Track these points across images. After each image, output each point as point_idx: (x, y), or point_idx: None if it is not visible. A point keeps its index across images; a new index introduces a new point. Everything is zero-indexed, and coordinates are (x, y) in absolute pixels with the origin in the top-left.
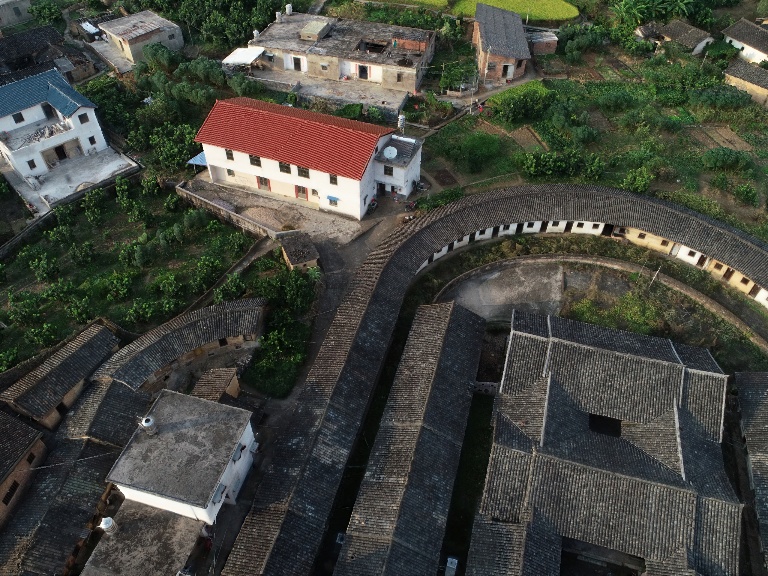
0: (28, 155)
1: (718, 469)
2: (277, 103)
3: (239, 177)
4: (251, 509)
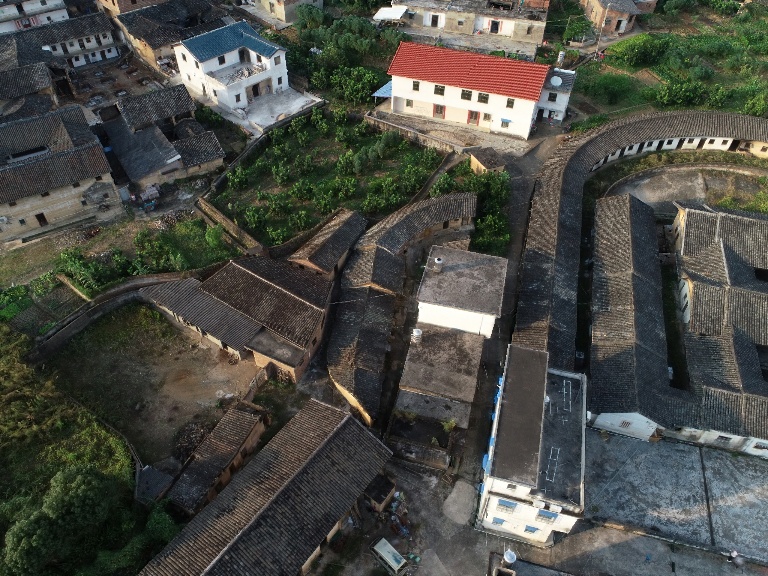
0: (237, 90)
1: None
2: None
3: (417, 107)
4: (515, 329)
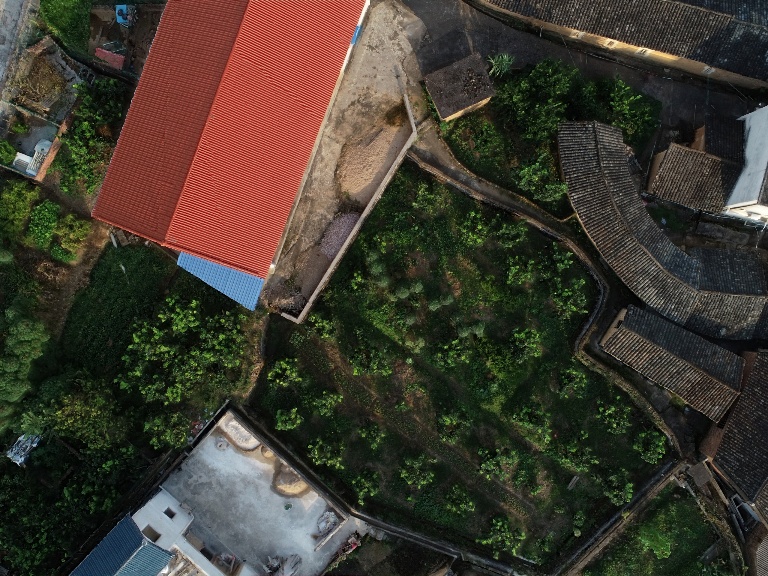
0: None
1: None
2: (16, 184)
3: None
4: None
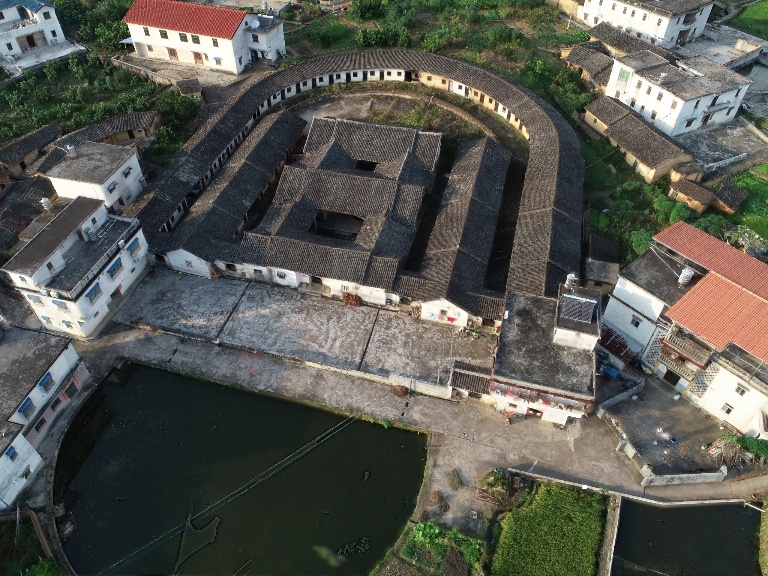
0: (7, 39)
1: (426, 182)
2: None
3: (156, 51)
4: None
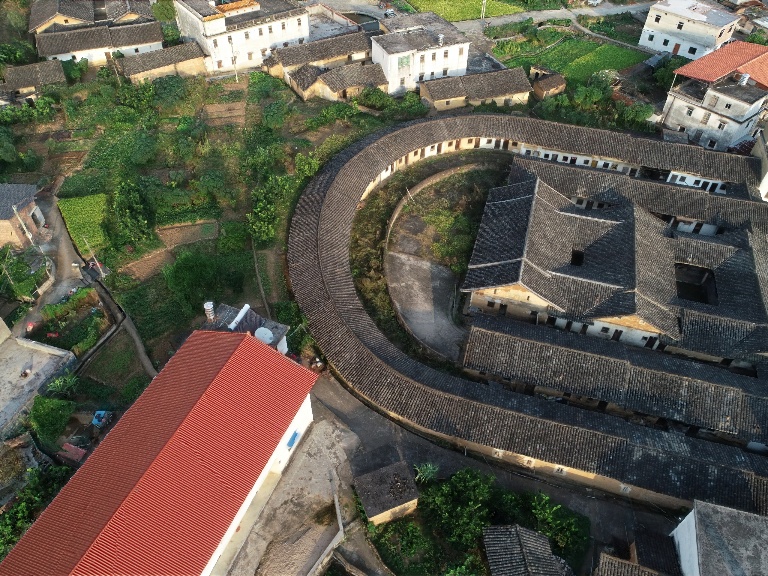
0: None
1: (596, 211)
2: None
3: None
4: None
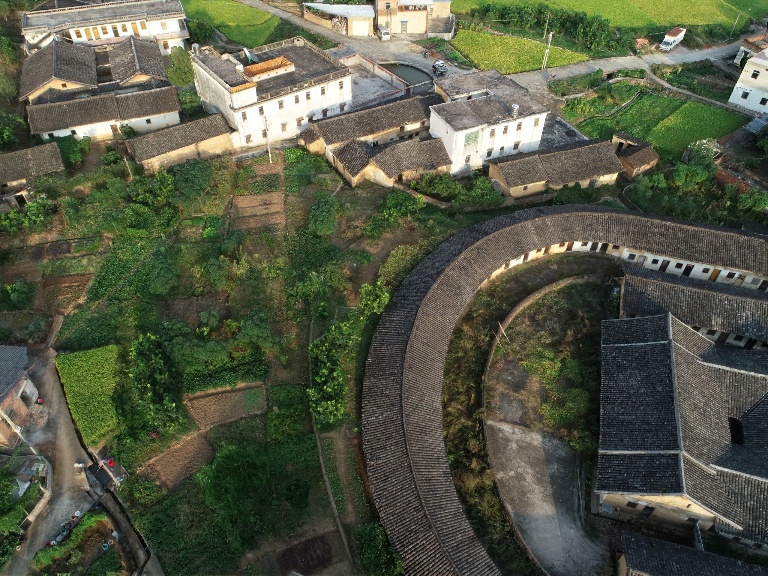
0: None
1: (742, 354)
2: None
3: None
4: None
